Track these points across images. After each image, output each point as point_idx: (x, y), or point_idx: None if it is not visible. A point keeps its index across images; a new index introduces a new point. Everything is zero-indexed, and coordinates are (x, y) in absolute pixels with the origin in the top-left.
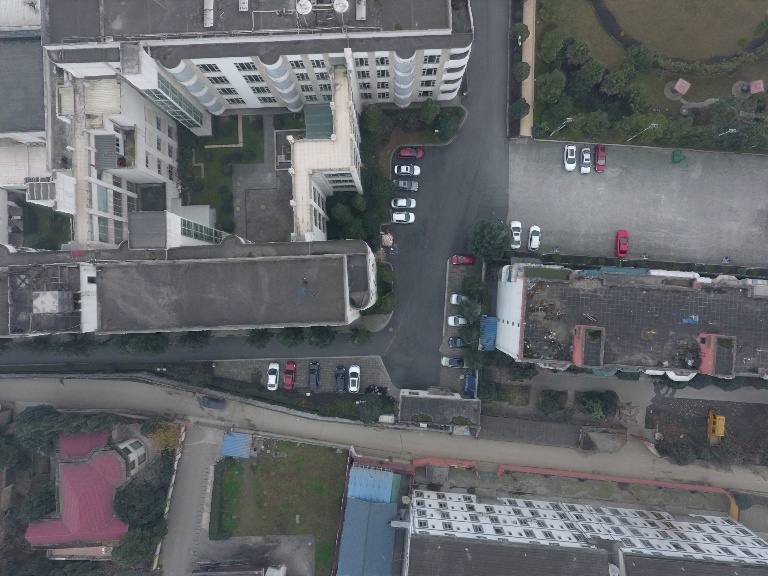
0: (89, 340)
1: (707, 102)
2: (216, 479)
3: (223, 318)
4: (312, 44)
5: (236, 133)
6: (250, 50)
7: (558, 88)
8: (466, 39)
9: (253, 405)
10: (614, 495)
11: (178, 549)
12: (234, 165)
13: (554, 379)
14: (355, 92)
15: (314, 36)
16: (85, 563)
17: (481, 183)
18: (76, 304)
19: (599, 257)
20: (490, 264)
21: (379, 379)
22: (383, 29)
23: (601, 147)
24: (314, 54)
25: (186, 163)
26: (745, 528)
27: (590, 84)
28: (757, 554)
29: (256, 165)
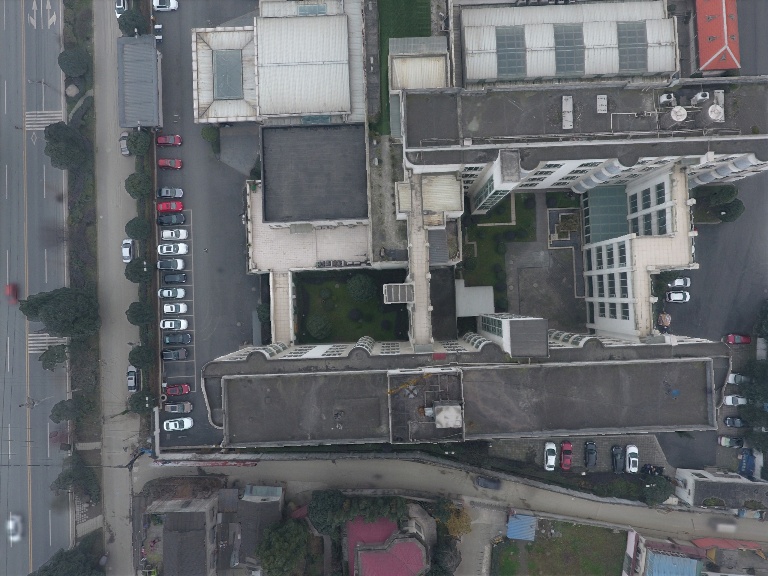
0: None
1: None
2: (495, 560)
3: (584, 421)
4: (670, 146)
5: (508, 211)
6: (607, 152)
7: None
8: None
9: (537, 487)
10: None
11: None
12: (506, 243)
13: None
14: None
15: (678, 140)
16: None
17: (753, 261)
18: None
19: None
20: None
21: (654, 458)
22: (741, 131)
23: None
24: (673, 156)
25: None
26: None
27: None
28: None
29: (528, 243)
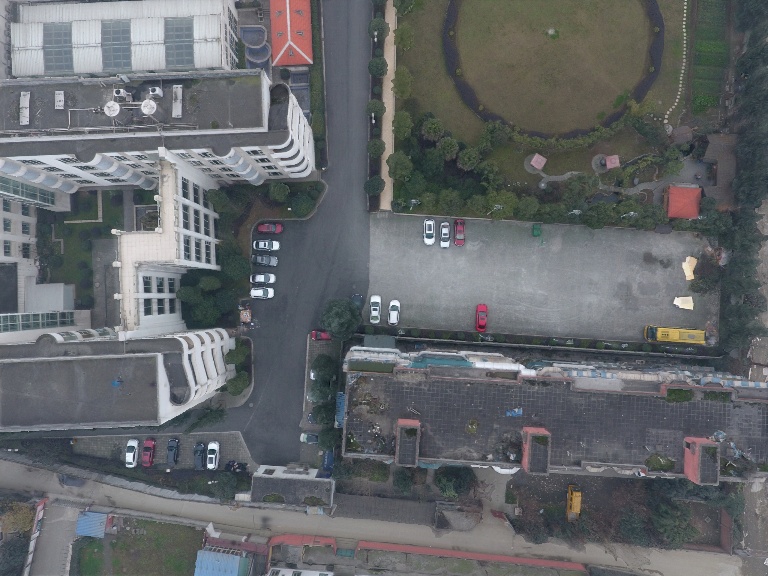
0: None
1: (567, 175)
2: (73, 558)
3: (39, 417)
4: (129, 141)
5: (96, 208)
6: (67, 147)
7: (404, 169)
8: (283, 136)
9: (108, 484)
10: (474, 571)
11: None
12: (94, 240)
13: None
14: (196, 177)
15: (128, 135)
16: None
17: (341, 257)
18: None
19: (458, 331)
20: (346, 341)
21: (239, 455)
22: (199, 126)
23: (460, 221)
24: (130, 152)
25: (46, 239)
26: None
27: (440, 163)
28: None
29: (116, 240)
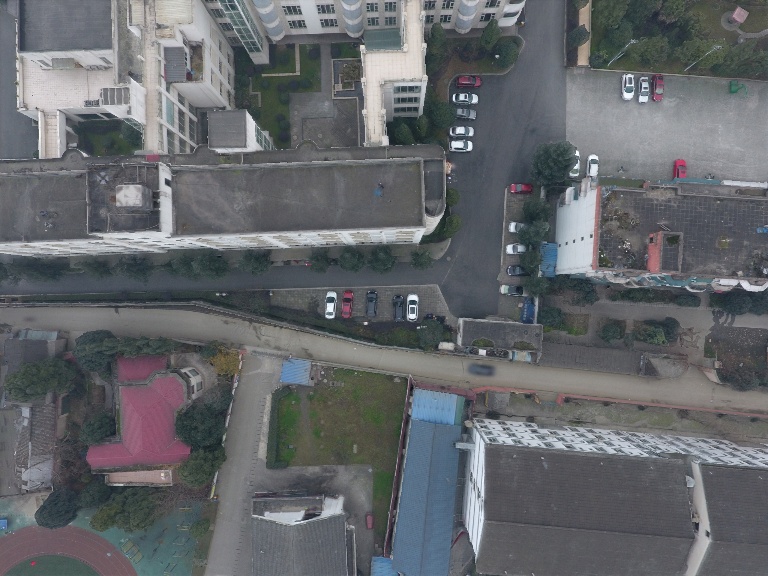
0: (148, 265)
1: (764, 32)
2: (273, 408)
3: (299, 223)
4: None
5: (293, 62)
6: None
7: (621, 10)
8: None
9: (312, 332)
10: (673, 424)
11: (234, 479)
12: (291, 94)
13: (613, 308)
14: None
15: None
16: (145, 488)
17: (539, 112)
18: (155, 203)
19: None
20: (550, 191)
21: (437, 308)
22: None
23: (659, 76)
24: None
25: (243, 92)
26: None
27: (652, 8)
28: None
29: (313, 94)
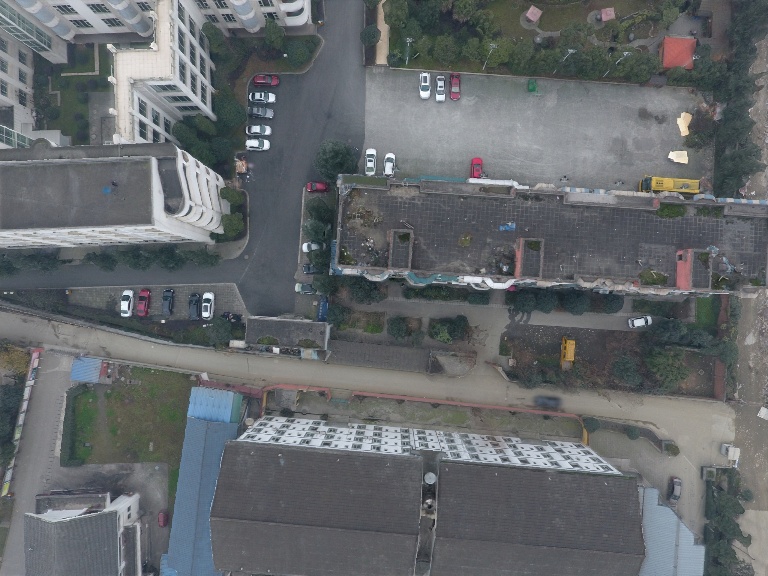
0: None
1: None
2: (68, 406)
3: (33, 221)
4: None
5: (93, 61)
6: None
7: (399, 9)
8: None
9: (103, 330)
10: (467, 421)
11: (31, 477)
12: (91, 93)
13: (409, 306)
14: (192, 10)
15: None
16: None
17: (337, 111)
18: None
19: None
20: None
21: (234, 306)
22: None
23: (456, 75)
24: None
25: (42, 91)
26: (590, 450)
27: (435, 7)
28: (584, 466)
29: (113, 93)
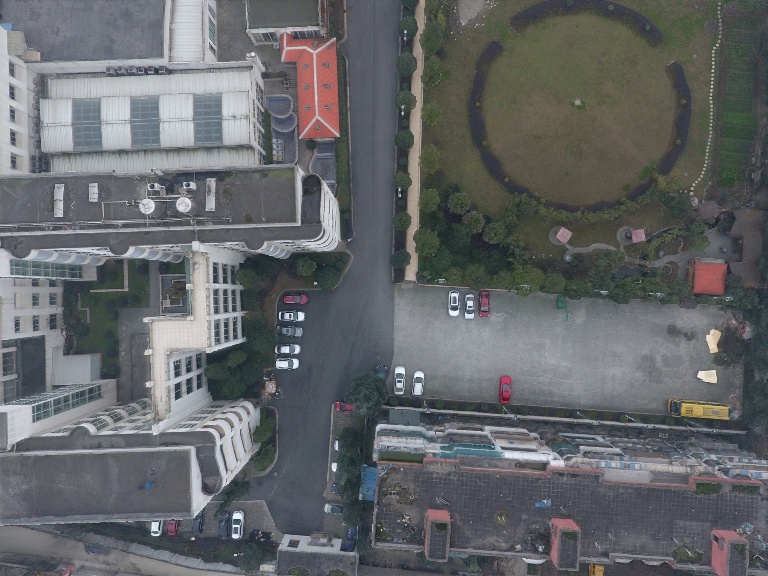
0: None
1: (592, 247)
2: None
3: (72, 508)
4: (162, 234)
5: (122, 277)
6: (100, 240)
7: (431, 248)
8: (315, 230)
9: (134, 554)
10: None
11: None
12: (120, 309)
13: None
14: (225, 257)
15: (162, 229)
16: None
17: (366, 328)
18: None
19: (482, 403)
20: None
21: (263, 524)
22: (232, 220)
23: (485, 293)
24: None
25: (72, 307)
26: None
27: (466, 240)
28: None
29: (142, 309)
